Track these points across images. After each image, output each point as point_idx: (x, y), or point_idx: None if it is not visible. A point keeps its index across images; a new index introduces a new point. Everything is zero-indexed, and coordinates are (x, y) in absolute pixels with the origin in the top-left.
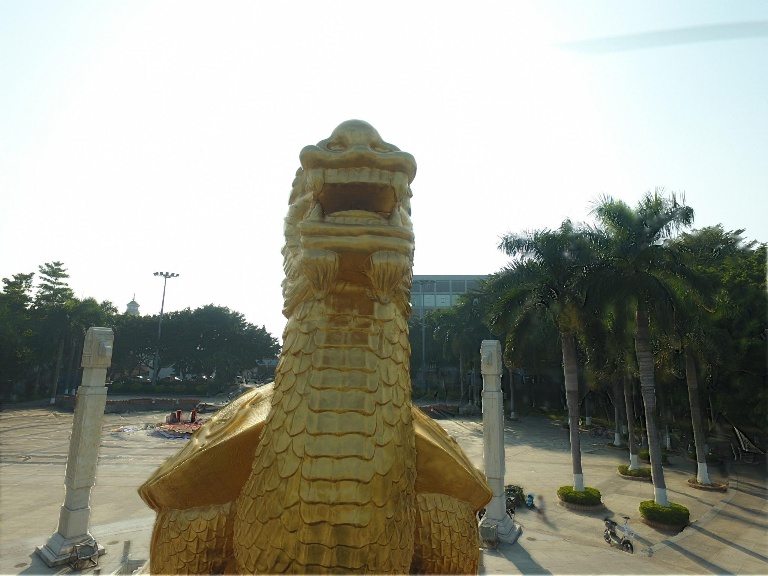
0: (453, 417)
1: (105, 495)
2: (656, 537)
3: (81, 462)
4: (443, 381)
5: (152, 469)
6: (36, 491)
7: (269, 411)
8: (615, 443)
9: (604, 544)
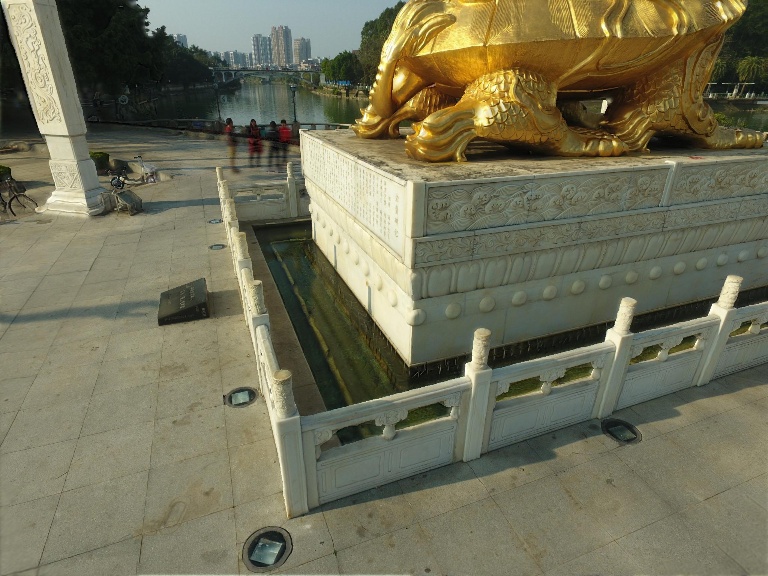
0: None
1: None
2: None
3: None
4: None
5: None
6: None
7: None
8: None
9: None
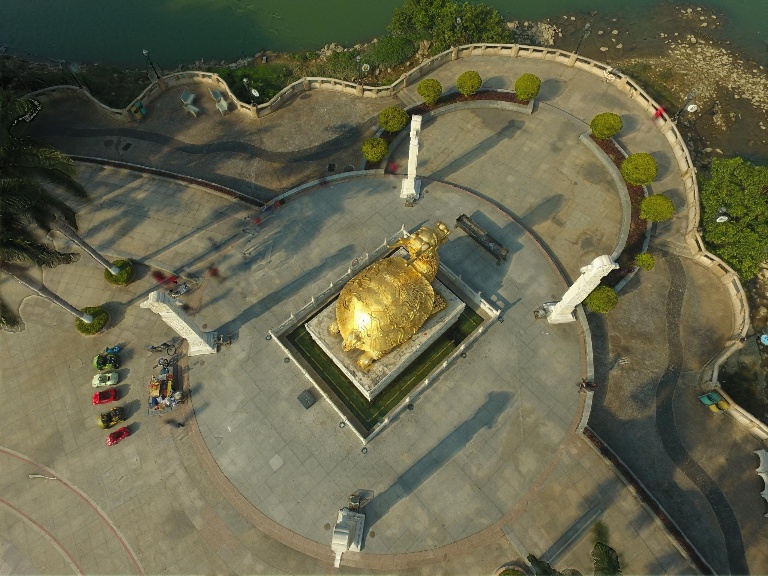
0: None
1: None
2: (153, 279)
3: None
4: None
5: None
6: None
7: None
8: None
9: None
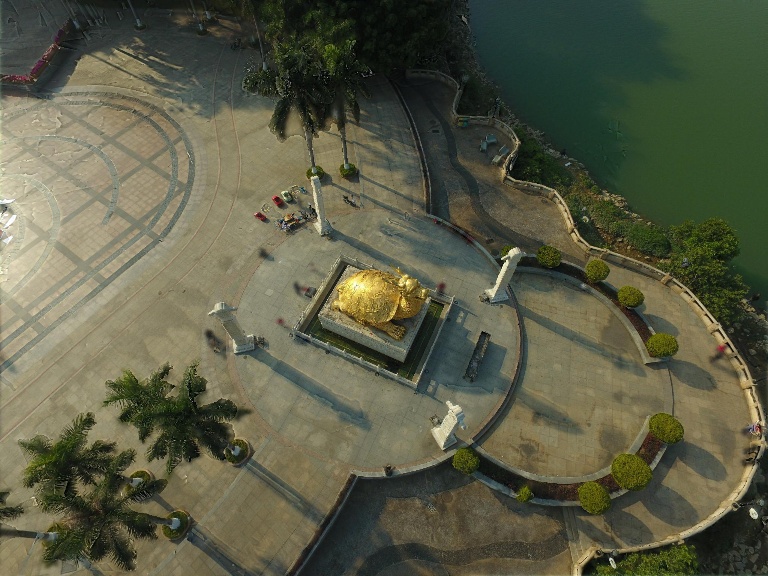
0: (84, 46)
1: (149, 330)
2: (353, 187)
3: (241, 332)
4: (40, 3)
5: (101, 302)
6: (112, 359)
7: (410, 309)
8: (264, 69)
9: (345, 204)
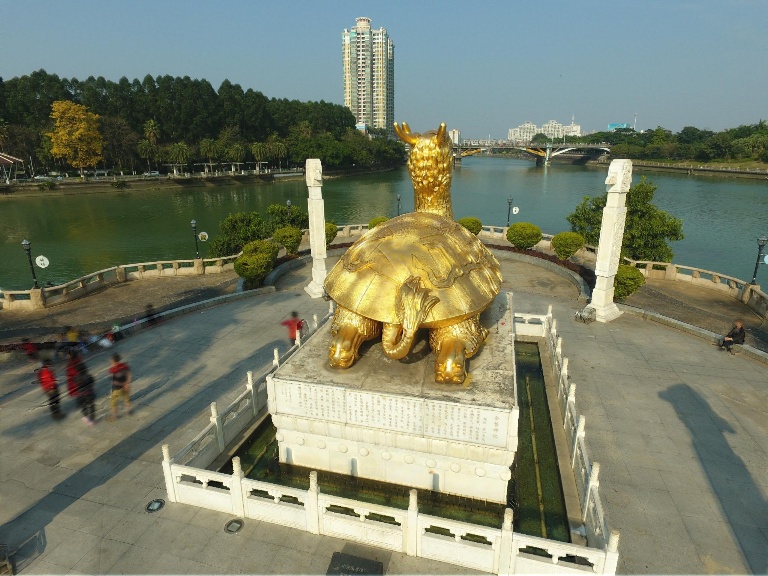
0: None
1: None
2: None
3: None
4: None
5: None
6: None
7: None
8: None
9: None
